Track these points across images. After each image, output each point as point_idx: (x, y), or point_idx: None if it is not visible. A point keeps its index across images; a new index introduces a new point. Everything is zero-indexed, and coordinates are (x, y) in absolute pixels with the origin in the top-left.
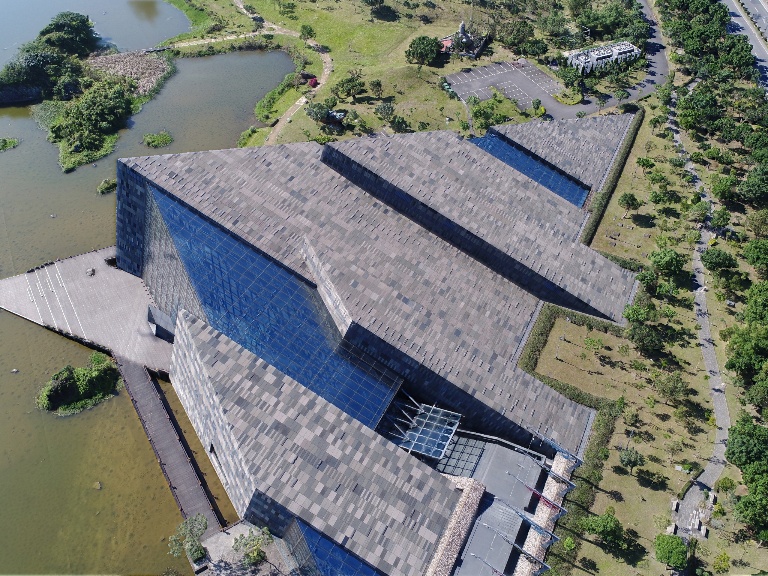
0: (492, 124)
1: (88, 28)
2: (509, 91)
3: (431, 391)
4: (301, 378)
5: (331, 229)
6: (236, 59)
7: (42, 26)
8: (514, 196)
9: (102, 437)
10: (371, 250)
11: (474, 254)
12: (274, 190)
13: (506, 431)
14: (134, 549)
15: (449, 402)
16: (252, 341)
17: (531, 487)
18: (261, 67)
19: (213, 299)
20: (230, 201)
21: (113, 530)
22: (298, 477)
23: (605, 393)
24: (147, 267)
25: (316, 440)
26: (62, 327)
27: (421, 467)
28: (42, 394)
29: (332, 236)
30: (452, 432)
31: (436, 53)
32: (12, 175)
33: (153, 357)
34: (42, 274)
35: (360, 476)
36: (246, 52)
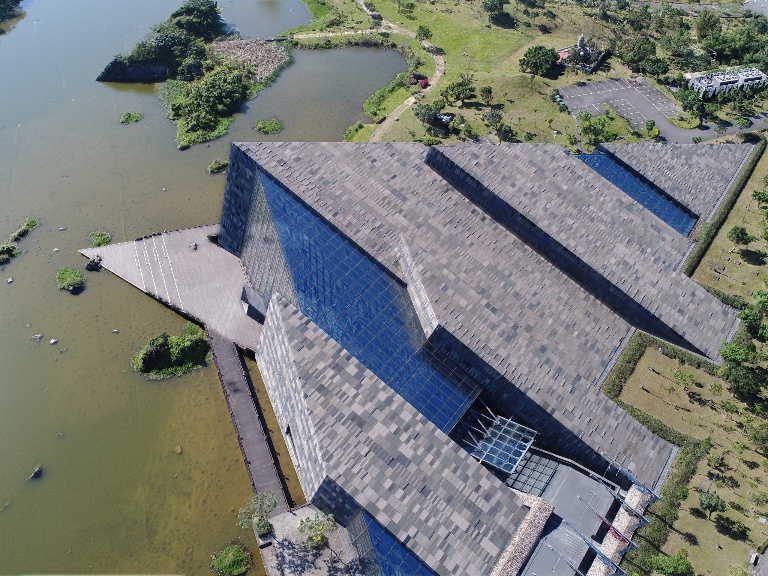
0: (601, 141)
1: (215, 14)
2: (623, 109)
3: (509, 404)
4: (382, 374)
5: (427, 231)
6: (351, 54)
7: (174, 9)
8: (616, 217)
9: (187, 404)
10: (464, 256)
11: (568, 272)
12: (376, 186)
13: (581, 455)
14: (205, 515)
15: (526, 417)
16: (339, 331)
17: (602, 516)
18: (374, 64)
19: (306, 286)
20: (333, 193)
21: (188, 494)
22: (368, 470)
23: (690, 431)
24: (246, 248)
25: (390, 436)
26: (162, 295)
27: (490, 478)
28: (138, 356)
29: (427, 238)
30: (525, 448)
31: (551, 64)
32: (132, 147)
33: (242, 335)
34: (149, 243)
35: (429, 478)
36: (361, 48)
